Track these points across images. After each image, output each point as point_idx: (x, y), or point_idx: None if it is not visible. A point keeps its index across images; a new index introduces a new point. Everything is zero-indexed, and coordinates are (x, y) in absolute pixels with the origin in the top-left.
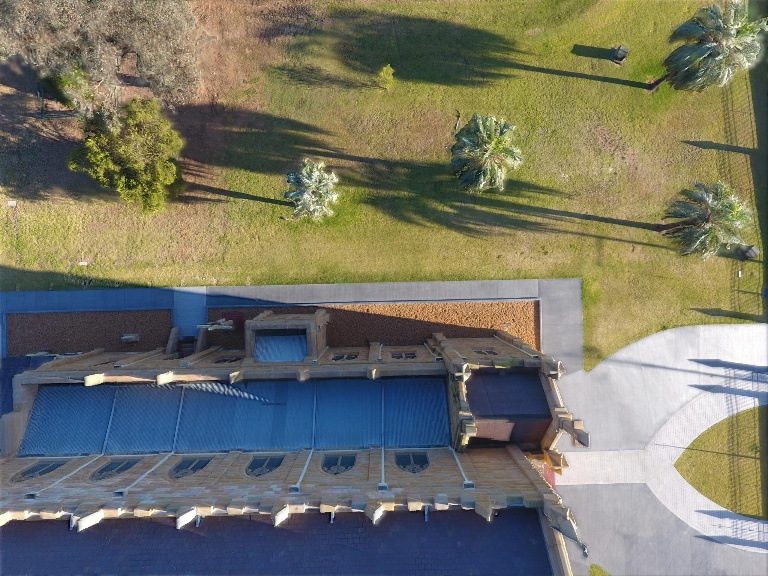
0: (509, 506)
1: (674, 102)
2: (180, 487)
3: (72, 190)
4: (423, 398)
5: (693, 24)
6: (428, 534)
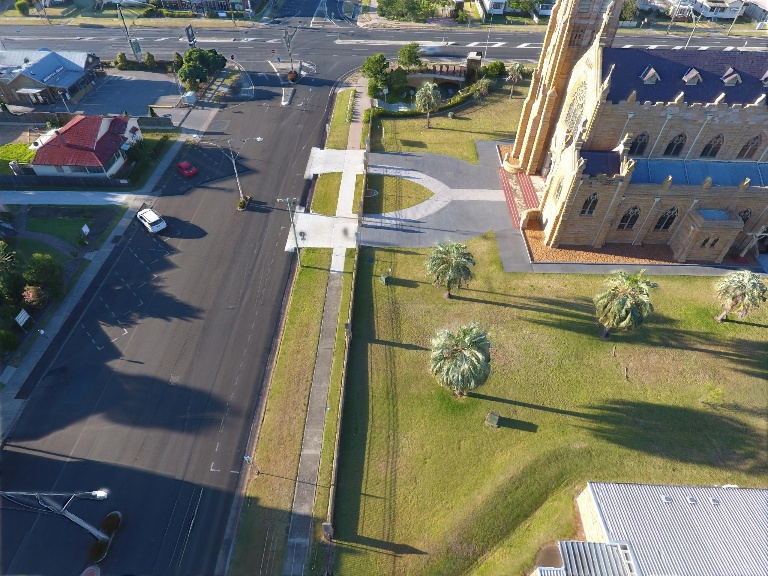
0: None
1: None
2: (760, 124)
3: None
4: None
5: (485, 367)
6: (648, 99)
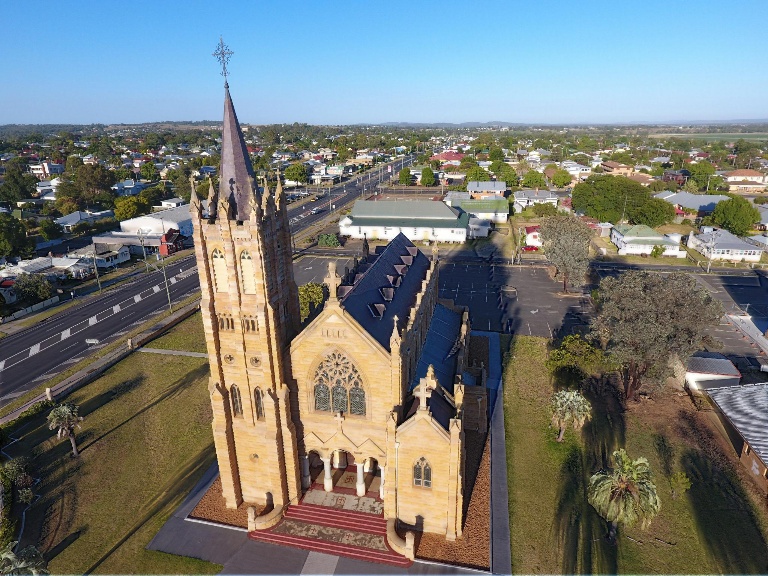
0: None
1: None
2: None
3: None
4: None
5: None
6: None
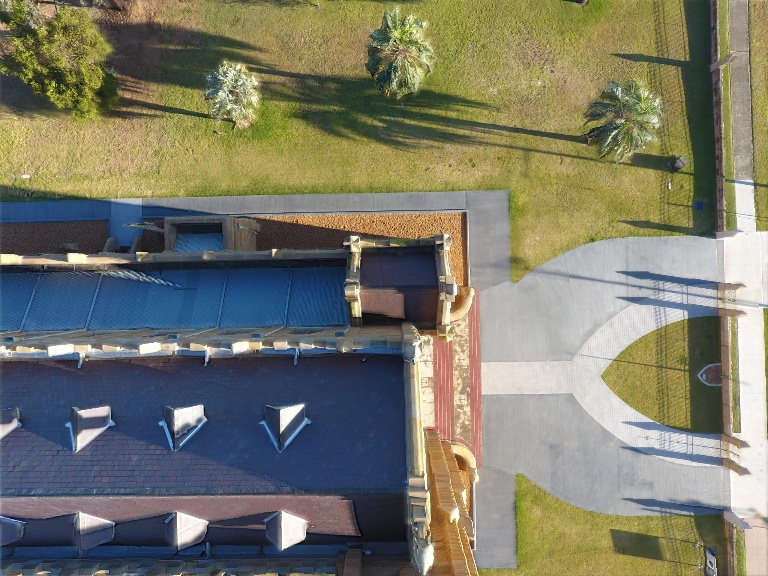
0: (378, 354)
1: (604, 15)
2: None
3: (16, 106)
4: (329, 284)
5: None
6: (294, 374)
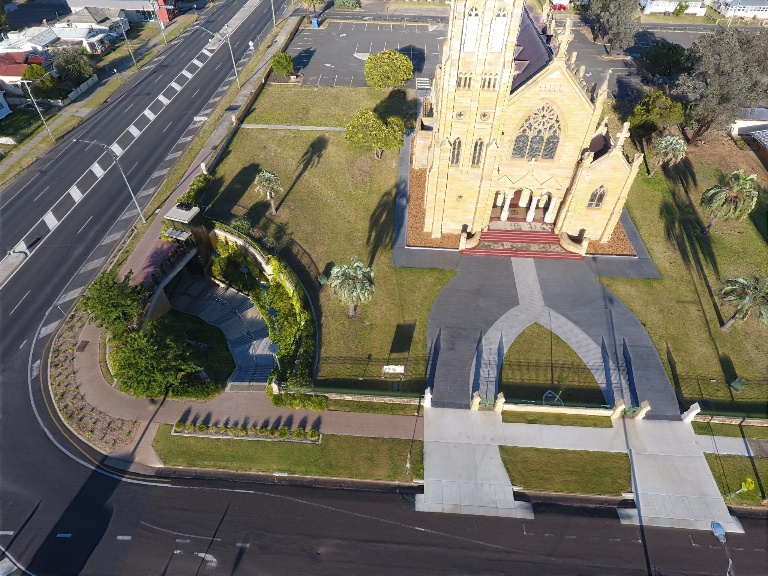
0: None
1: None
2: None
3: (622, 116)
4: None
5: None
6: None
